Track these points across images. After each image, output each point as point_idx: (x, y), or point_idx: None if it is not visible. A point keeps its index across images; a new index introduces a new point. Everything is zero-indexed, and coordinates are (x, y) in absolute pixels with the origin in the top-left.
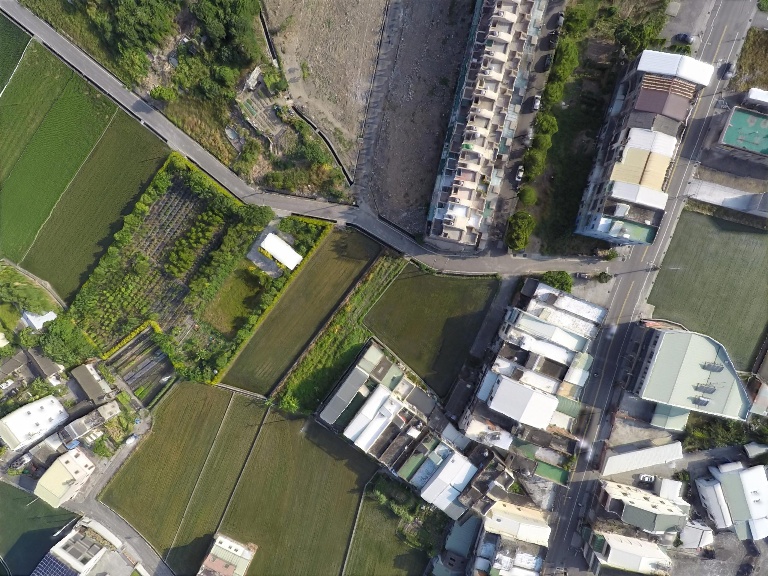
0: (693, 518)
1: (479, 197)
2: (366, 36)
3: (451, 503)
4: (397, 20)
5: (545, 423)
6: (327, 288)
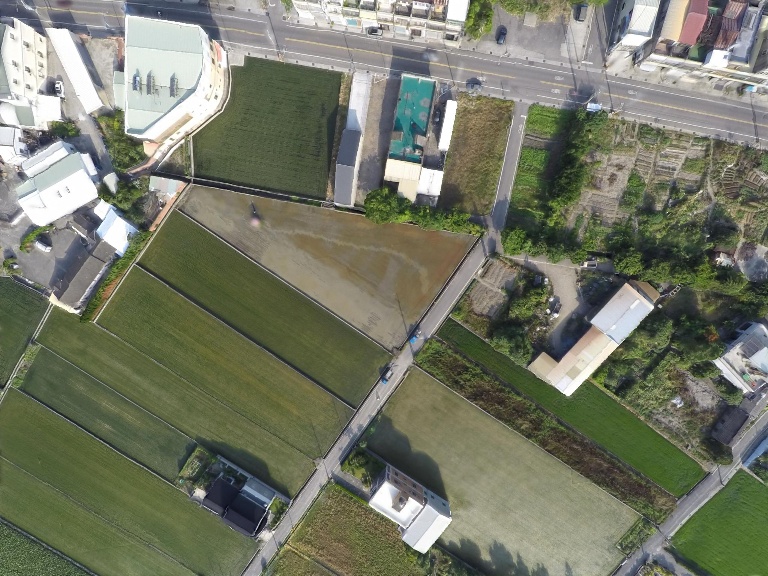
0: (30, 147)
1: None
2: None
3: None
4: None
5: None
6: None
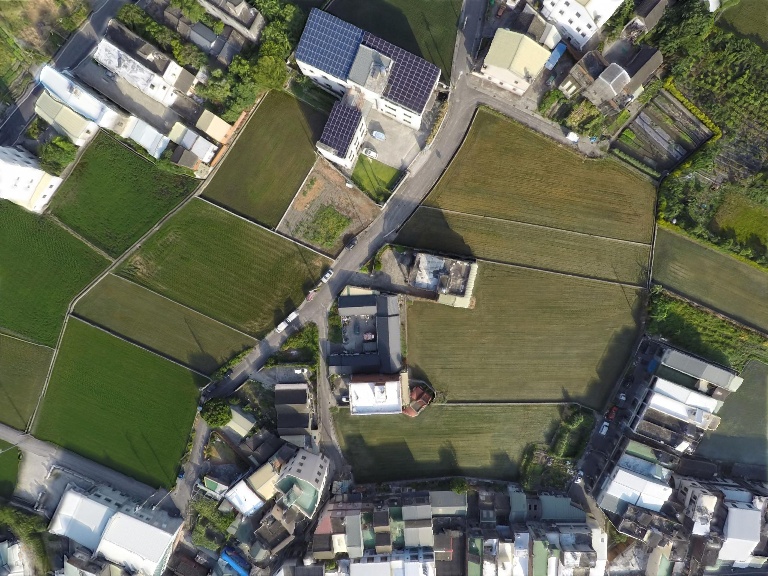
0: None
1: None
2: None
3: (618, 498)
4: None
5: (724, 556)
6: None
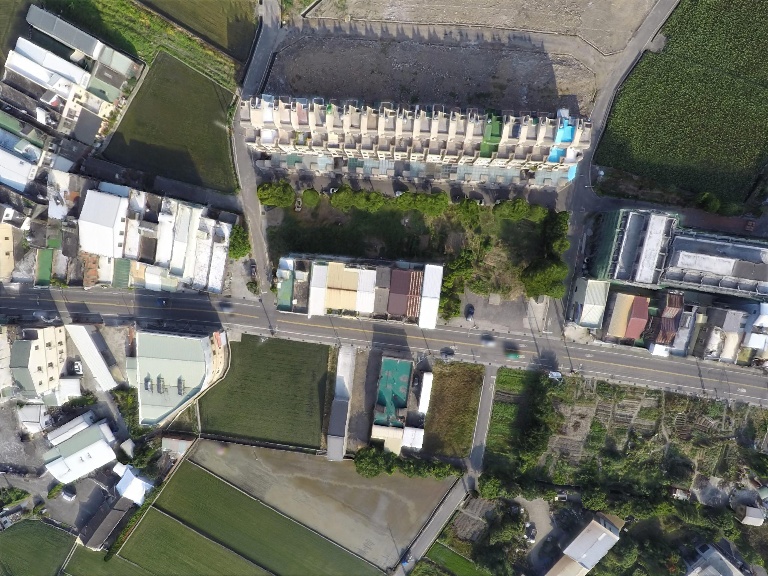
0: (53, 415)
1: (291, 137)
2: (450, 7)
3: None
4: (467, 39)
5: (87, 248)
6: (190, 5)
